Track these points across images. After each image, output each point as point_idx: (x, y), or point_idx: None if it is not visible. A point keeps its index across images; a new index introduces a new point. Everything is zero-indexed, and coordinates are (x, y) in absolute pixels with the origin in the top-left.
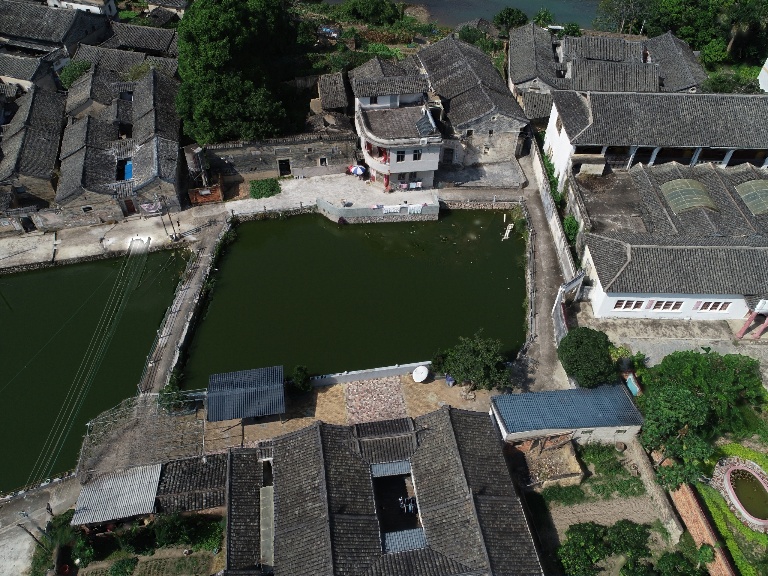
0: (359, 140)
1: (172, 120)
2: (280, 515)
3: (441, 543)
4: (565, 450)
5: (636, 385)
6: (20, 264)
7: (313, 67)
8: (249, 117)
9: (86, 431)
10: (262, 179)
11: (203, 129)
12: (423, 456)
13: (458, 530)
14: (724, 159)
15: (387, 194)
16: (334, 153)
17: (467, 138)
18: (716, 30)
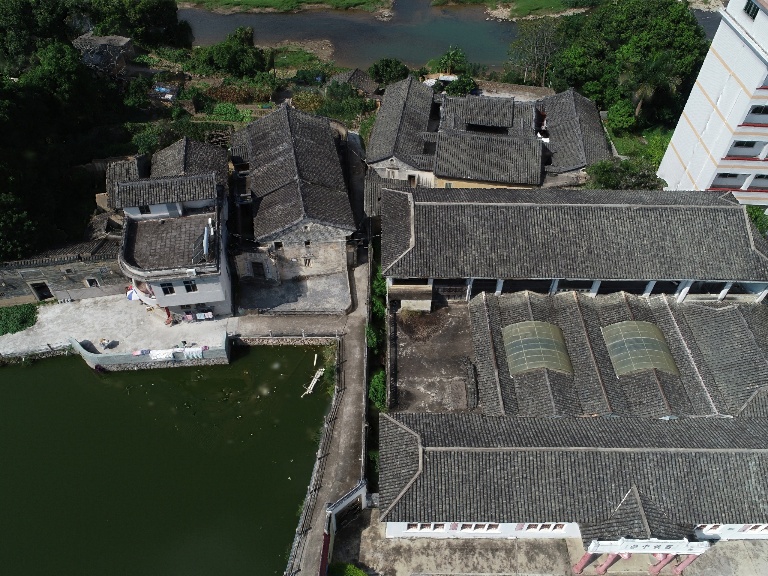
0: None
1: None
2: None
3: None
4: None
5: None
6: None
7: None
8: None
9: None
10: (16, 305)
11: None
12: None
13: None
14: (592, 287)
15: (169, 327)
16: (104, 273)
17: (277, 250)
18: (624, 88)
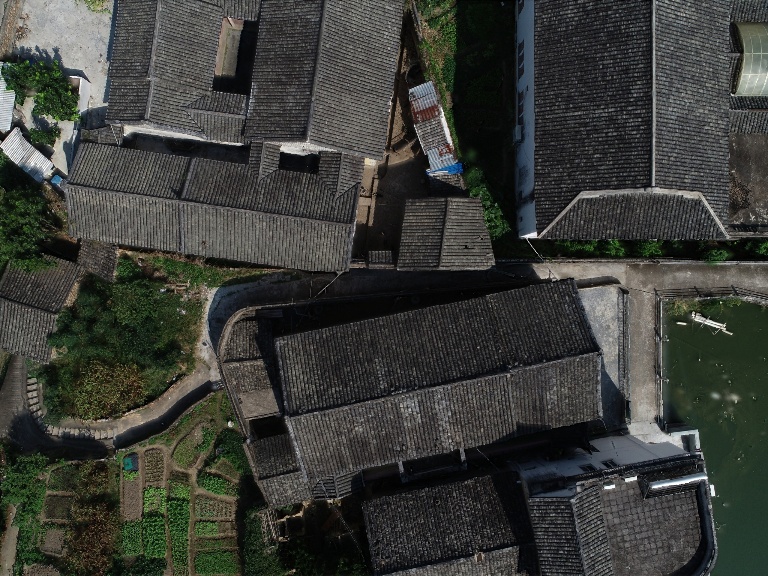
0: None
1: None
2: None
3: None
4: None
5: None
6: None
7: None
8: None
9: None
10: None
11: None
12: None
13: None
14: None
15: None
16: None
17: None
18: None
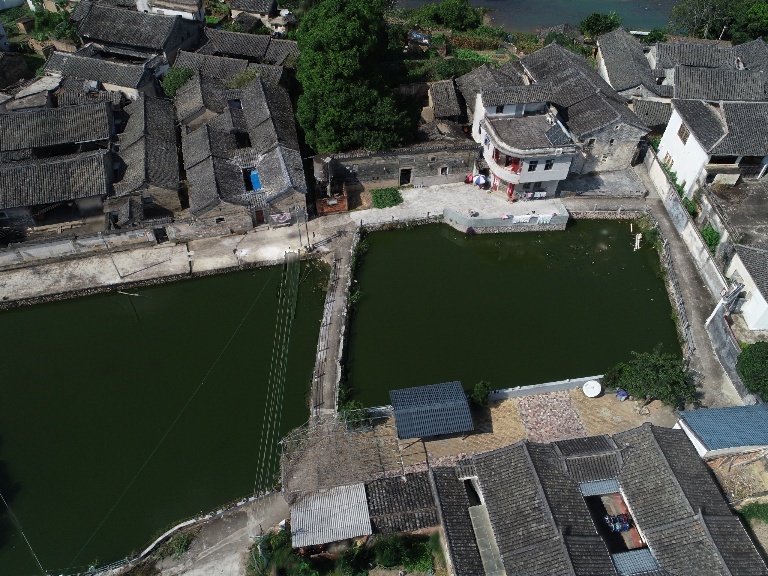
0: (482, 149)
1: (288, 129)
2: (502, 536)
3: (676, 565)
4: (755, 466)
5: None
6: (159, 276)
7: (409, 74)
8: (376, 126)
9: (281, 450)
10: (382, 188)
11: (329, 138)
12: (631, 475)
13: (692, 551)
14: None
15: (511, 203)
16: (456, 162)
17: (588, 147)
18: None
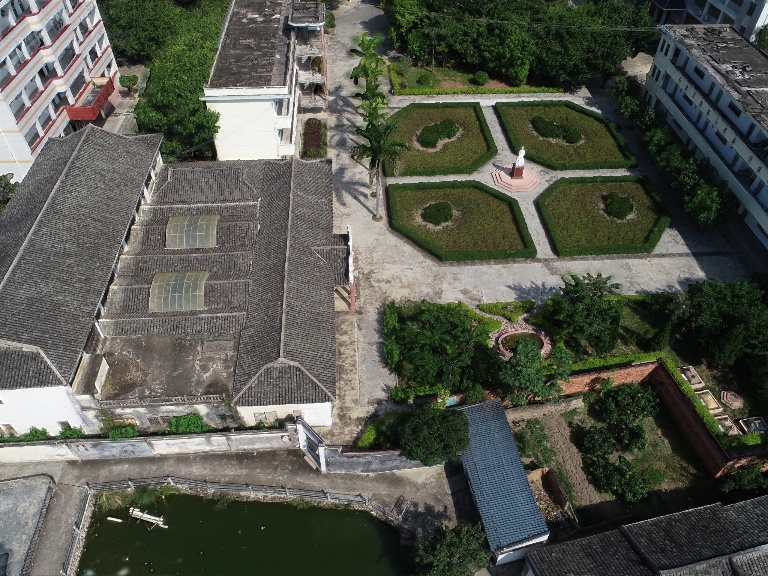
0: None
1: None
2: None
3: None
4: None
5: (451, 398)
6: None
7: None
8: None
9: None
10: None
11: None
12: None
13: None
14: None
15: None
16: None
17: None
18: None
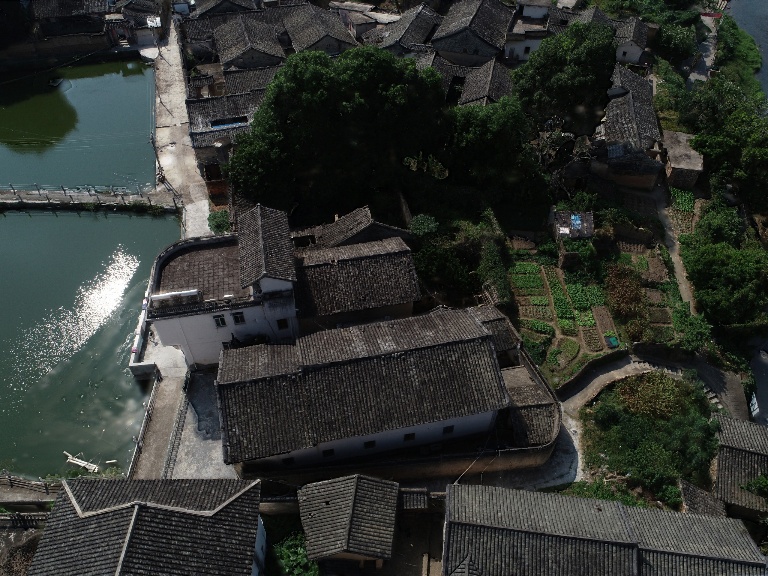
0: None
1: None
2: None
3: None
4: None
5: None
6: None
7: None
8: None
9: None
10: None
11: None
12: None
13: None
14: None
15: None
16: None
17: None
18: None
